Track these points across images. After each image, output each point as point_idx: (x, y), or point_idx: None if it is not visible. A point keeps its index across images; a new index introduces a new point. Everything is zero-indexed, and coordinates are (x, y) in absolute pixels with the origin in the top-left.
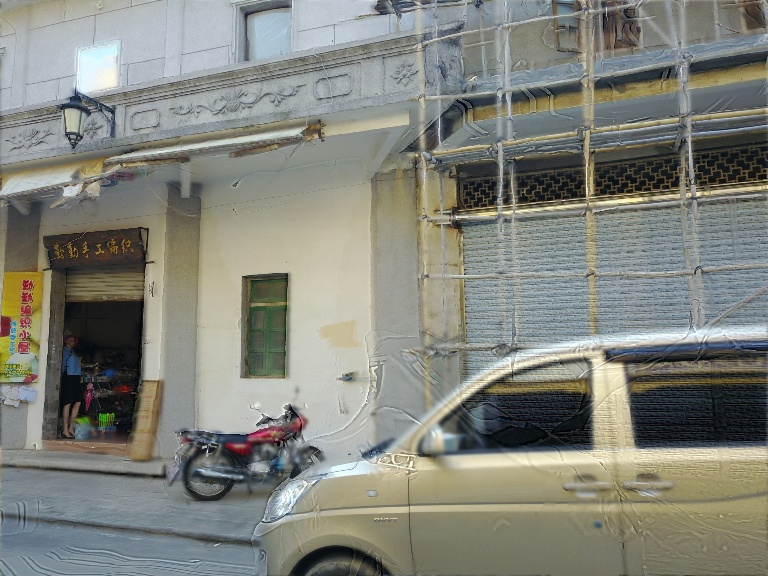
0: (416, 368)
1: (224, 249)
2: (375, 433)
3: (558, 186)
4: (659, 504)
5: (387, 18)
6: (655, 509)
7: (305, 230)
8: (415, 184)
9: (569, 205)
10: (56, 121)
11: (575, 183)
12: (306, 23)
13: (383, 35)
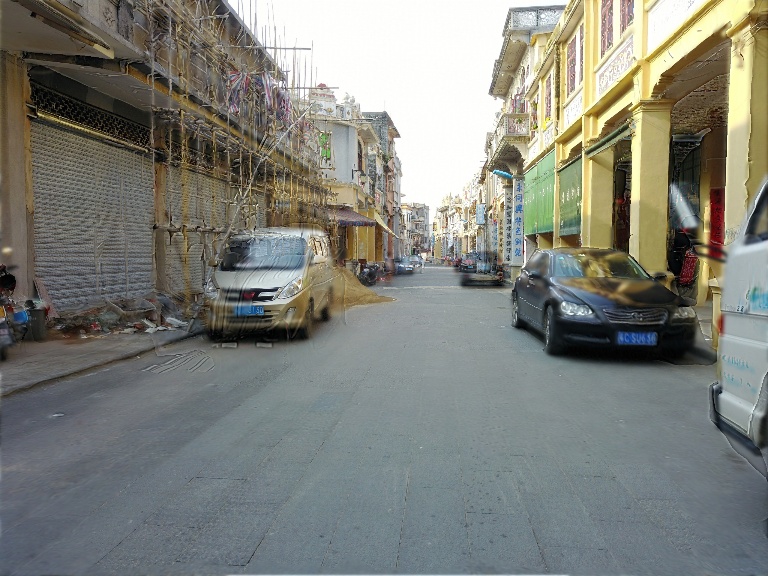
0: None
1: None
2: None
3: None
4: None
5: None
6: None
7: None
8: None
9: (91, 131)
10: None
11: None
12: None
13: None
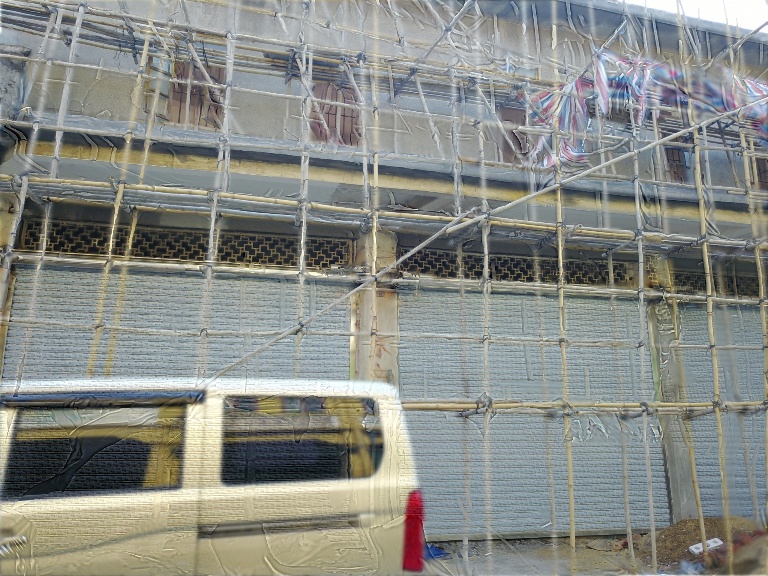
0: None
1: None
2: None
3: None
4: (159, 568)
5: None
6: (153, 574)
7: None
8: None
9: None
10: None
11: (150, 243)
12: None
13: None
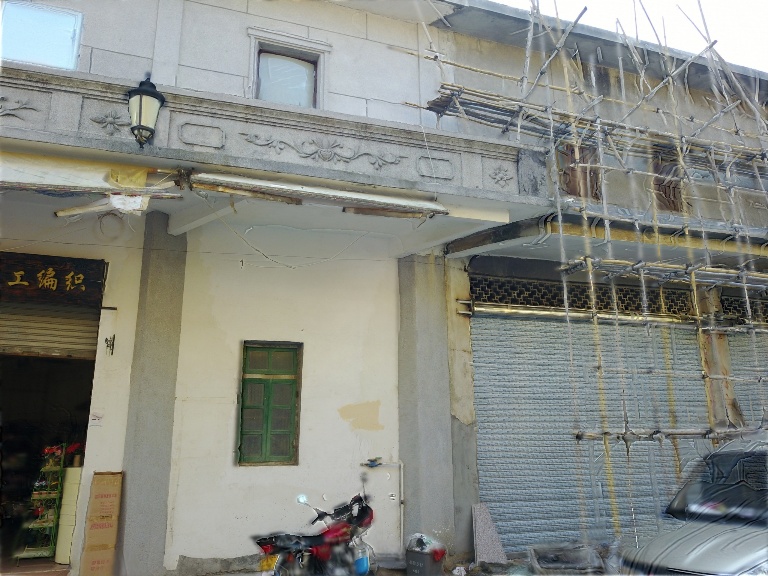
0: None
1: (220, 305)
2: None
3: (541, 294)
4: None
5: (417, 112)
6: None
7: (325, 298)
8: (444, 272)
9: (562, 312)
10: (43, 94)
11: (552, 294)
12: (337, 87)
13: (485, 137)
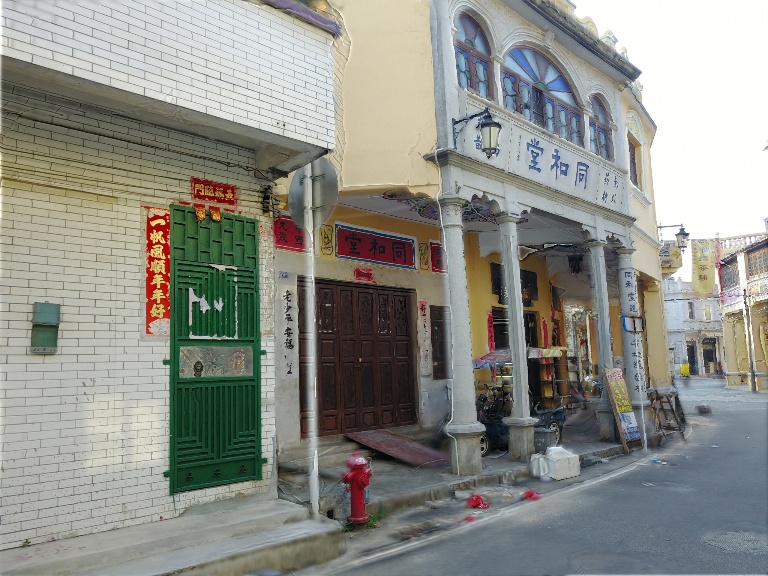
0: None
1: (721, 342)
2: None
3: None
4: None
5: None
6: None
7: None
8: None
9: None
10: None
11: None
12: None
13: None
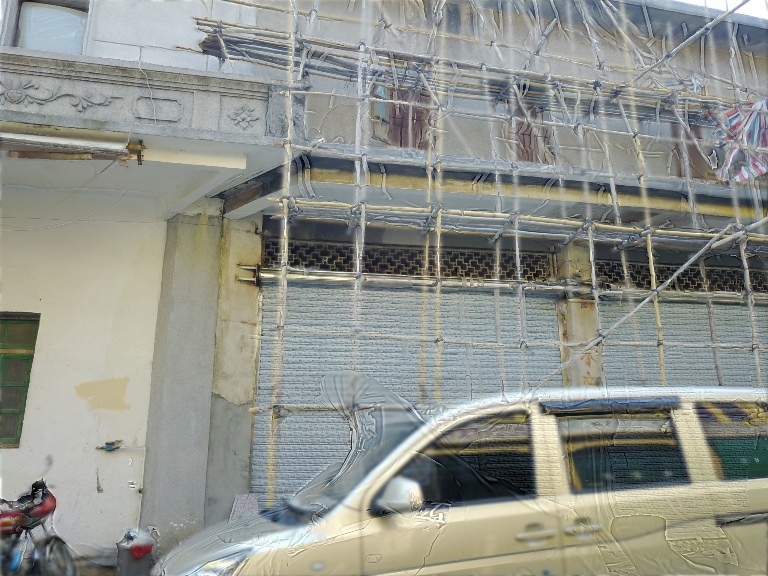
0: (414, 411)
1: None
2: (418, 480)
3: None
4: None
5: (204, 59)
6: None
7: (73, 264)
8: (220, 233)
9: (372, 278)
10: None
11: (373, 259)
12: (105, 34)
13: None
